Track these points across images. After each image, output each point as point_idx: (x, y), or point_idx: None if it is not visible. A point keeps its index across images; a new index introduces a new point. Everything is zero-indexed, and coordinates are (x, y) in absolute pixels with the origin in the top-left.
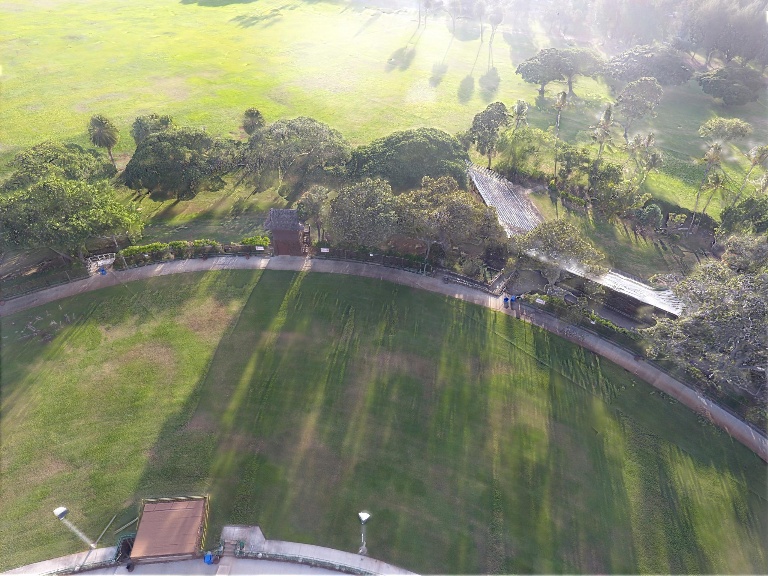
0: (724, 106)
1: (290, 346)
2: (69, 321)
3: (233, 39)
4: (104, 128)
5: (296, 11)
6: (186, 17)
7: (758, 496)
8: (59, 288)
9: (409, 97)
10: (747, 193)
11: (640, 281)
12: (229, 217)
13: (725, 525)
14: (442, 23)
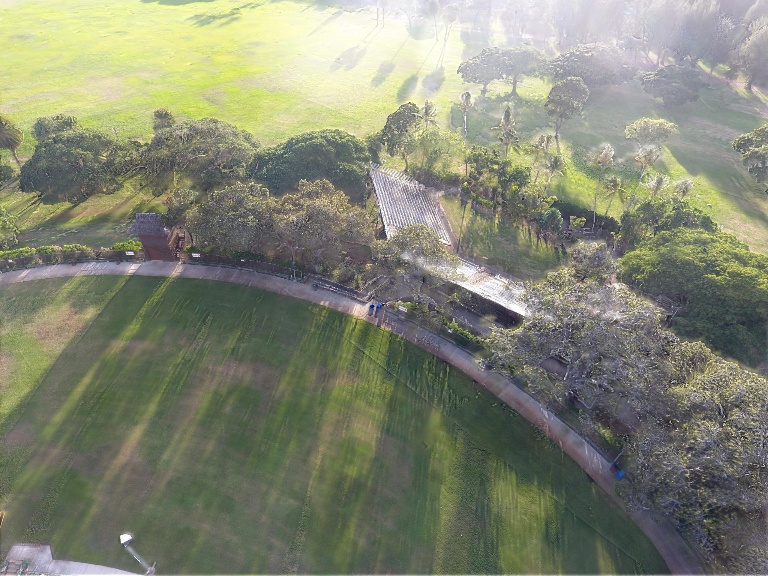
0: (666, 106)
1: (136, 355)
2: None
3: (184, 38)
4: (4, 129)
5: (257, 10)
6: (143, 16)
7: (573, 515)
8: None
9: (346, 97)
10: (666, 195)
11: None
12: (125, 220)
13: (532, 545)
14: (402, 22)
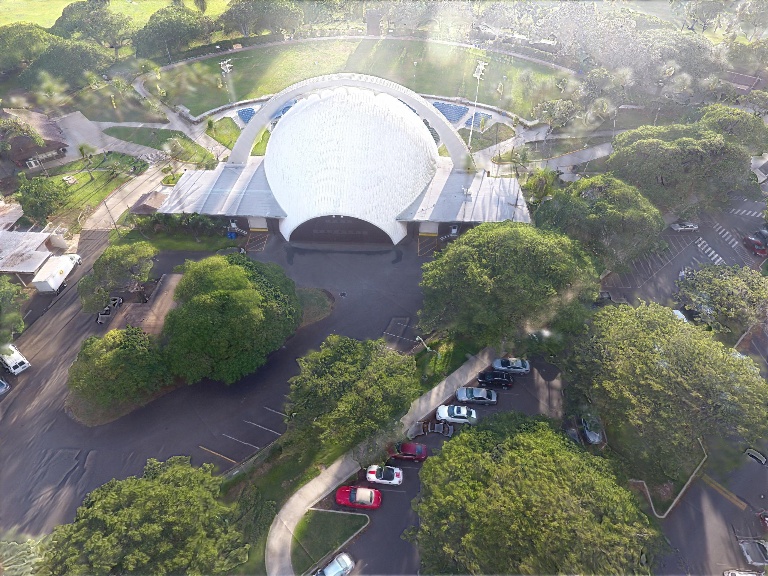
0: None
1: (379, 56)
2: (283, 50)
3: None
4: None
5: None
6: None
7: None
8: (273, 43)
9: None
10: None
11: None
12: None
13: None
14: None
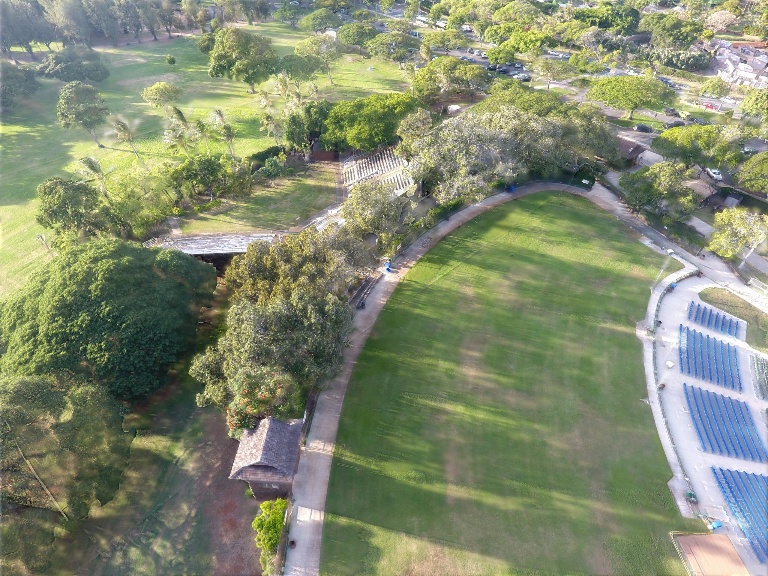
0: None
1: (466, 465)
2: None
3: None
4: None
5: None
6: None
7: (537, 209)
8: None
9: None
10: (236, 125)
11: (340, 203)
12: None
13: (557, 226)
14: None
